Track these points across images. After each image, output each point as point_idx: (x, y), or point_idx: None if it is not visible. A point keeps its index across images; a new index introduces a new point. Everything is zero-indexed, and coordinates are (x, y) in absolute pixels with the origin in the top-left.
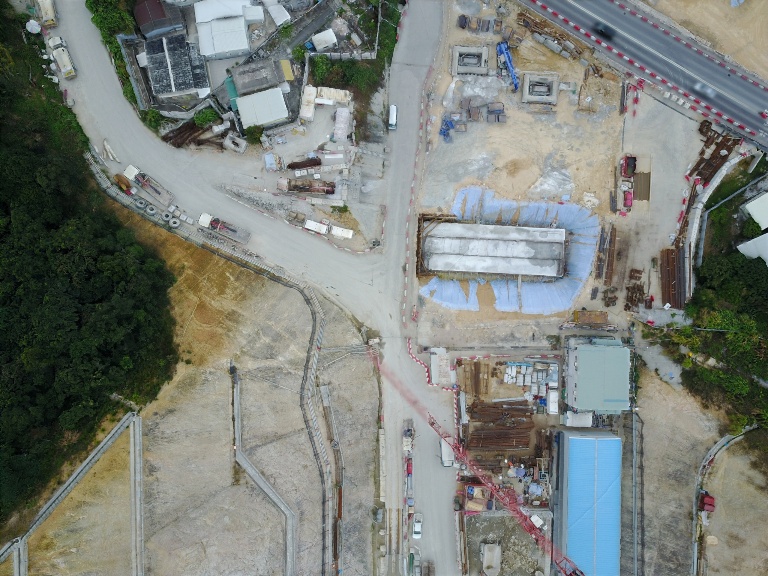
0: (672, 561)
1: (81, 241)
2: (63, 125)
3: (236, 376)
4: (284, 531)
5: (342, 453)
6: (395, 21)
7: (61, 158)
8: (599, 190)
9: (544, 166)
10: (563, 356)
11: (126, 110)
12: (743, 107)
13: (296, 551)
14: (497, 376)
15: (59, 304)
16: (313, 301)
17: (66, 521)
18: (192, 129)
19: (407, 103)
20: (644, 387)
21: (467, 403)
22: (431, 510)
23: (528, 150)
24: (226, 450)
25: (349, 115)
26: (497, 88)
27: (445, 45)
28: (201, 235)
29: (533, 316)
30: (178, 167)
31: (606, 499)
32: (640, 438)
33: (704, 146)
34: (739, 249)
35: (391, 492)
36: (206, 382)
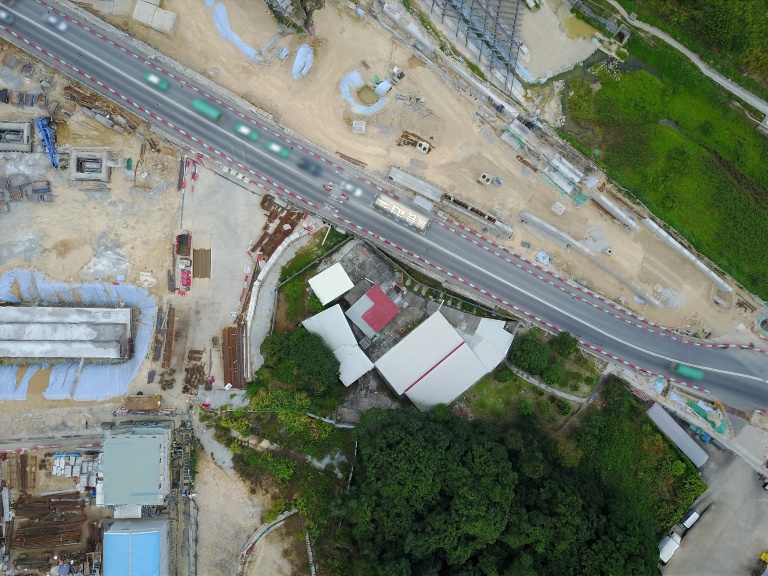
0: None
1: None
2: None
3: None
4: None
5: None
6: None
7: None
8: (156, 269)
9: (97, 246)
10: None
11: None
12: (307, 180)
13: None
14: (46, 468)
15: None
16: None
17: None
18: None
19: None
20: (201, 472)
21: (12, 499)
22: None
23: (80, 229)
24: None
25: None
26: (45, 165)
27: None
28: None
29: (86, 403)
30: None
31: None
32: (195, 526)
33: (267, 221)
34: (304, 325)
35: None
36: None
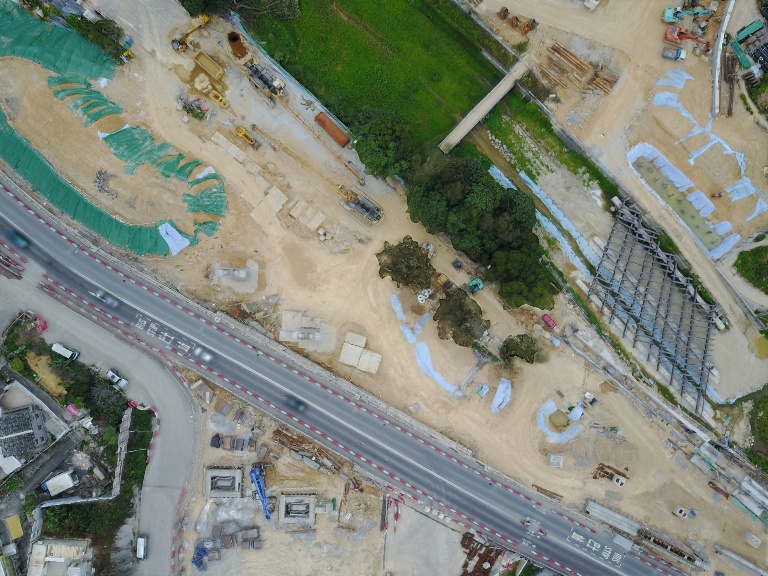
0: None
1: None
2: None
3: None
4: None
5: None
6: (146, 442)
7: None
8: None
9: None
10: None
11: None
12: (505, 516)
13: None
14: None
15: None
16: None
17: None
18: None
19: (159, 528)
20: None
21: None
22: None
23: (286, 573)
24: None
25: (86, 564)
26: (254, 509)
27: (198, 467)
28: None
29: None
30: None
31: None
32: None
33: (467, 558)
34: None
35: None
36: None
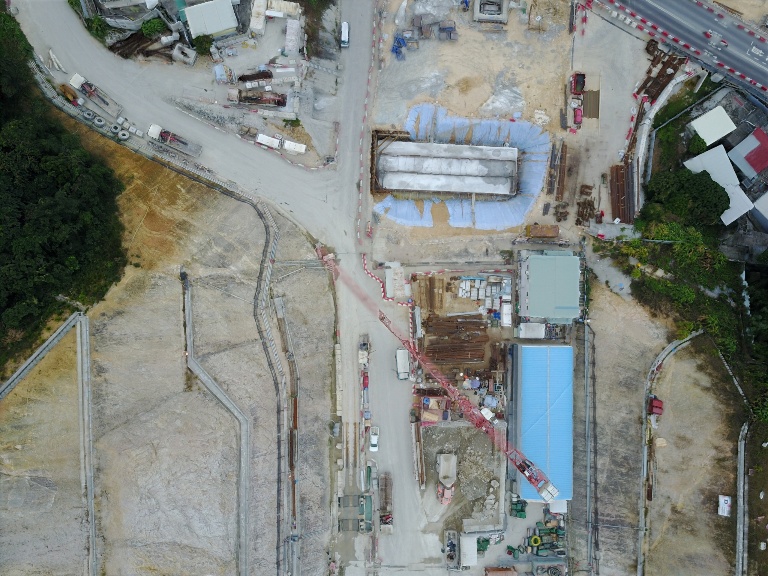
0: (623, 465)
1: (24, 140)
2: (6, 32)
3: (187, 282)
4: (237, 436)
5: (297, 364)
6: None
7: (3, 59)
8: (550, 107)
9: (496, 84)
10: (516, 270)
11: (72, 20)
12: (688, 27)
13: (250, 456)
14: (452, 291)
15: (1, 201)
16: (267, 216)
17: (10, 417)
18: (140, 40)
19: (359, 21)
20: (595, 299)
21: (422, 318)
22: (388, 424)
23: (480, 68)
24: (177, 356)
25: (300, 29)
26: (449, 7)
27: None
28: (151, 148)
29: (486, 232)
30: (127, 79)
31: (558, 405)
32: (592, 349)
33: (651, 65)
34: (686, 165)
35: (348, 406)
36: (156, 287)
